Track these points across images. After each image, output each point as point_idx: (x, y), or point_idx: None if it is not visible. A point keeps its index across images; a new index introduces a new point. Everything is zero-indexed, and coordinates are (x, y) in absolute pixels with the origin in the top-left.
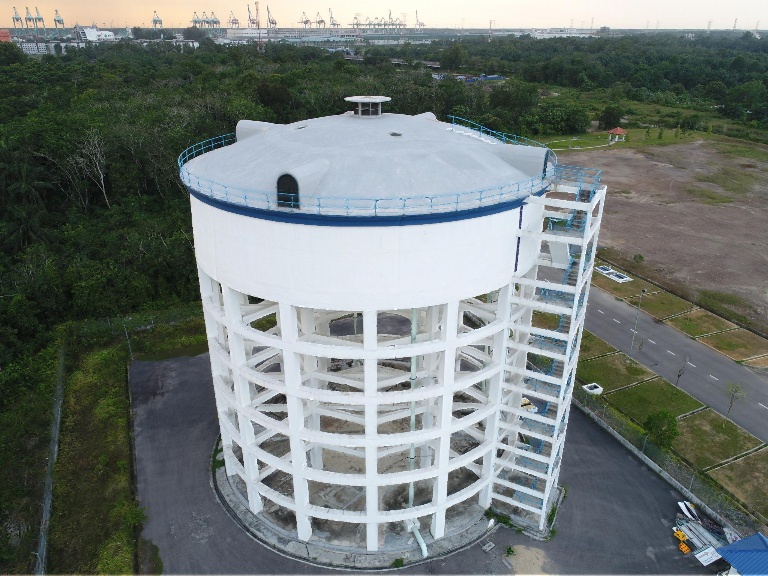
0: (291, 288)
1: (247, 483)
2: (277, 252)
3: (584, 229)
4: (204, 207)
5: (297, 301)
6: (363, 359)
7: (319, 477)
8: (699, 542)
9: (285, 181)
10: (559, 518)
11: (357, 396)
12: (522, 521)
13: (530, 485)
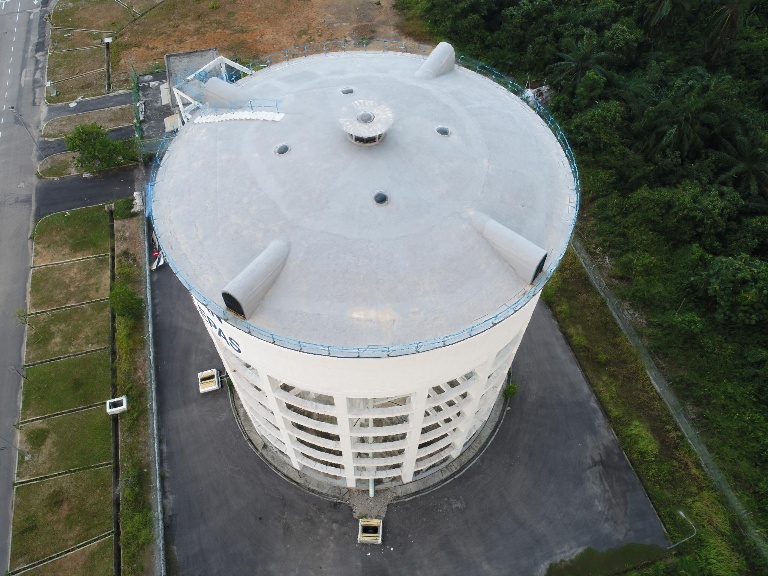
0: None
1: None
2: None
3: None
4: None
5: None
6: None
7: None
8: None
9: None
10: None
11: None
12: None
13: None
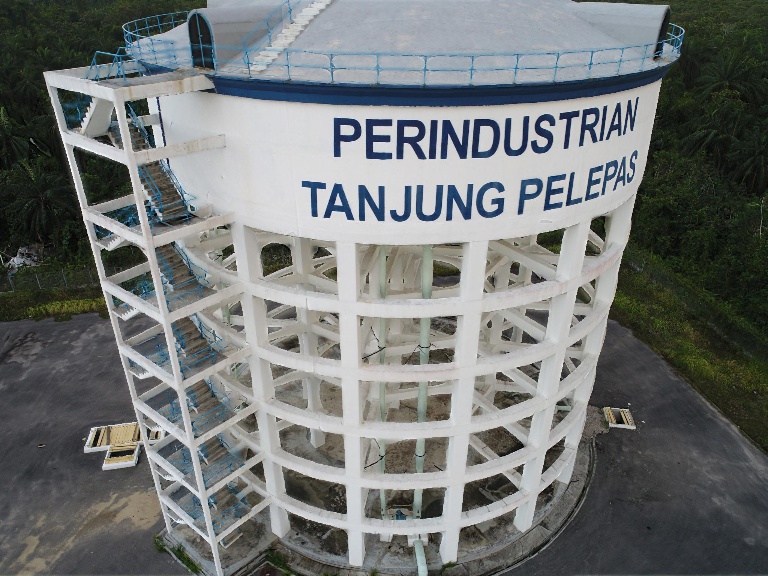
0: None
1: None
2: None
3: None
4: None
5: None
6: None
7: None
8: None
9: None
10: (178, 568)
11: None
12: None
13: (239, 545)
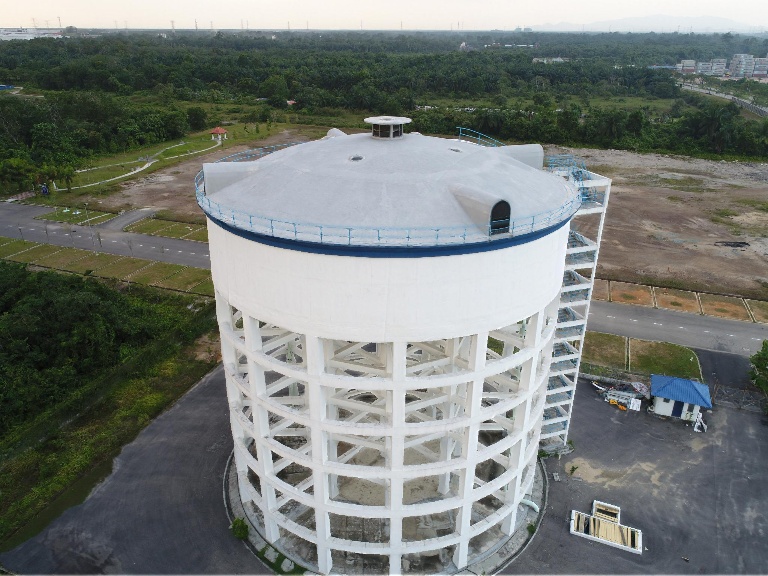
0: (492, 314)
1: (392, 554)
2: (483, 282)
3: (604, 199)
4: (368, 264)
5: (496, 325)
6: (533, 356)
7: (487, 491)
8: (624, 400)
9: (499, 208)
10: None
11: (524, 394)
12: (552, 447)
13: None
